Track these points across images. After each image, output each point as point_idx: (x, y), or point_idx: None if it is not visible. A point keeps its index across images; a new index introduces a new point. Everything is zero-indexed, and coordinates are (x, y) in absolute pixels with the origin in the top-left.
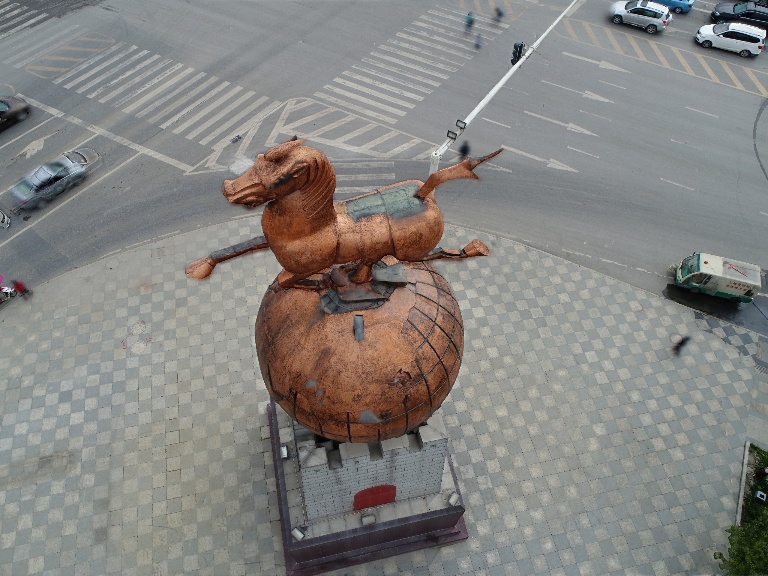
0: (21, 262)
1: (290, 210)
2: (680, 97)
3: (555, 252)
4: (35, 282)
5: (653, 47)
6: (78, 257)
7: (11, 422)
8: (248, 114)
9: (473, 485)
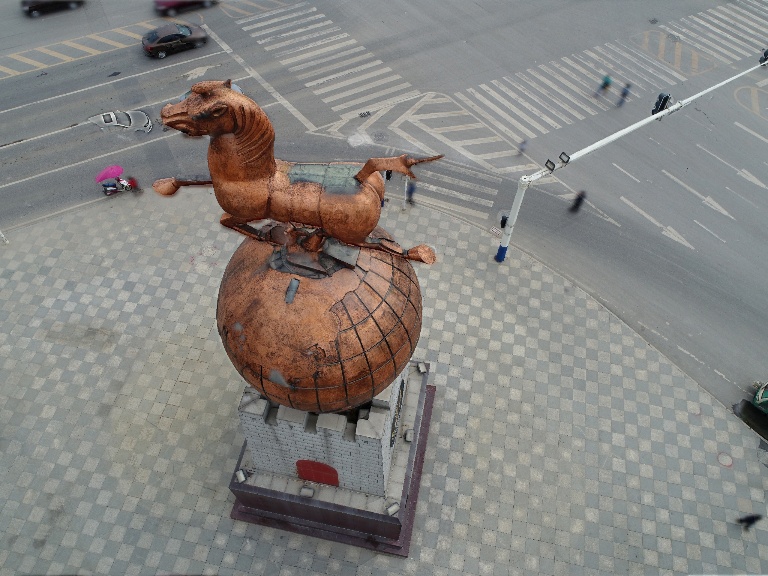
0: (146, 164)
1: (225, 150)
2: None
3: (629, 321)
4: (149, 184)
5: None
6: None
7: (81, 290)
8: (386, 95)
9: (436, 511)
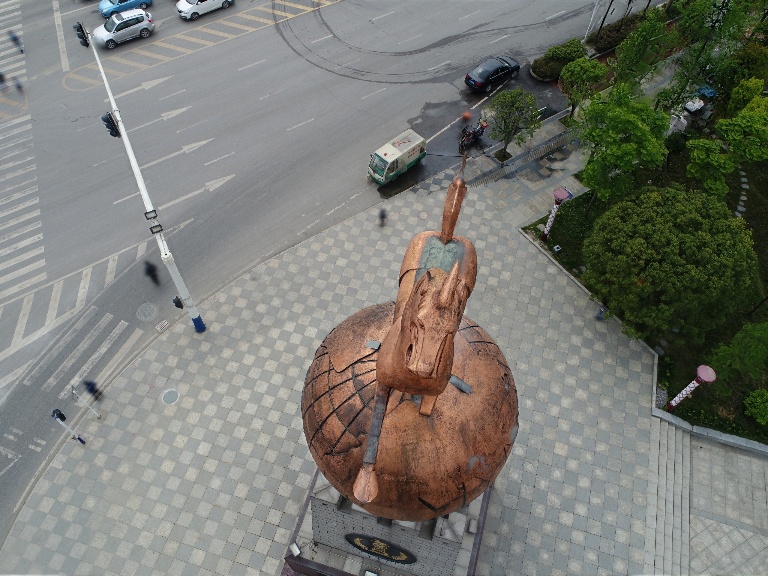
0: None
1: None
2: (226, 66)
3: (296, 241)
4: None
5: (162, 45)
6: None
7: None
8: None
9: None
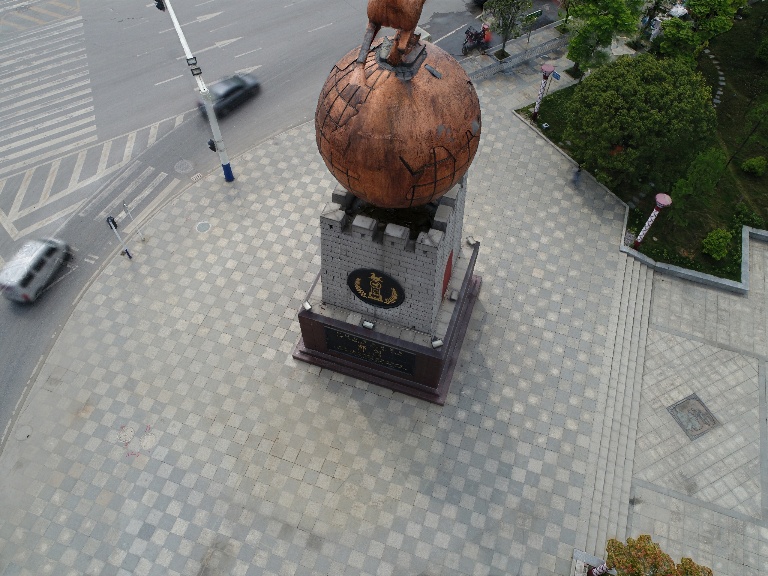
0: None
1: None
2: None
3: None
4: None
5: None
6: None
7: None
8: None
9: None
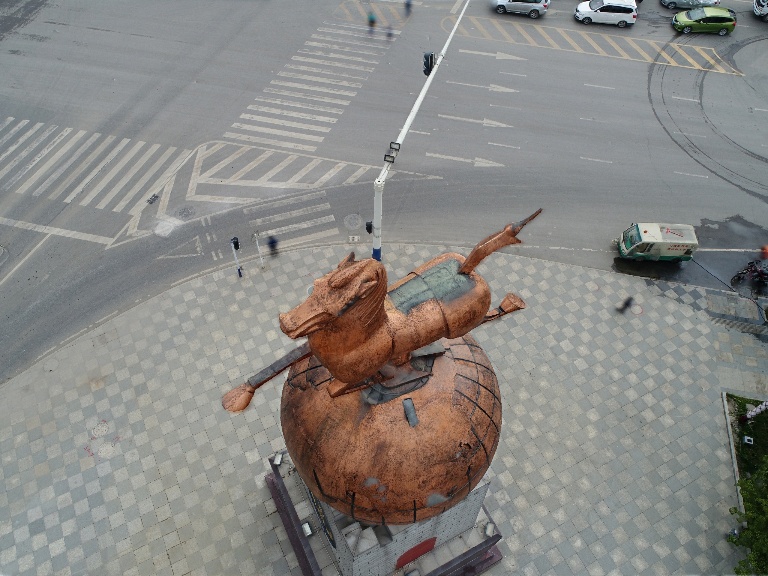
0: None
1: (346, 325)
2: (577, 75)
3: (505, 250)
4: None
5: (540, 31)
6: (8, 366)
7: None
8: (159, 169)
9: (492, 503)
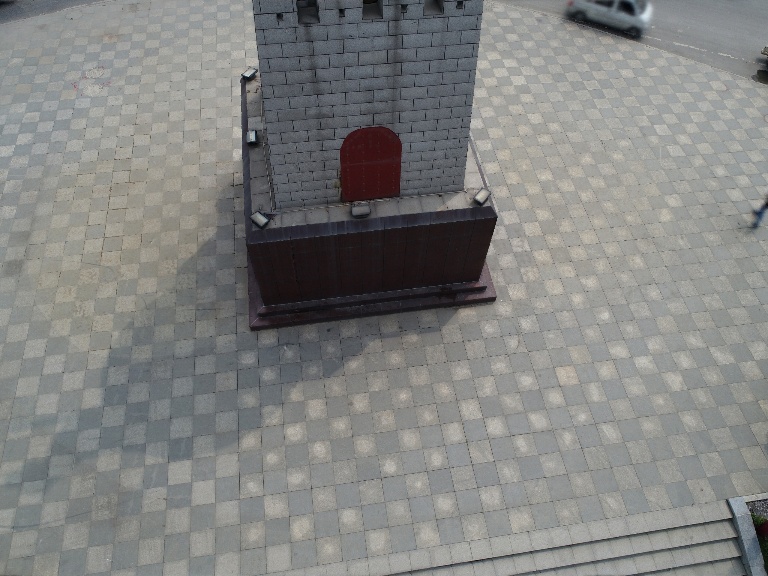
0: None
1: None
2: None
3: (616, 33)
4: None
5: None
6: (35, 9)
7: None
8: None
9: (505, 246)
